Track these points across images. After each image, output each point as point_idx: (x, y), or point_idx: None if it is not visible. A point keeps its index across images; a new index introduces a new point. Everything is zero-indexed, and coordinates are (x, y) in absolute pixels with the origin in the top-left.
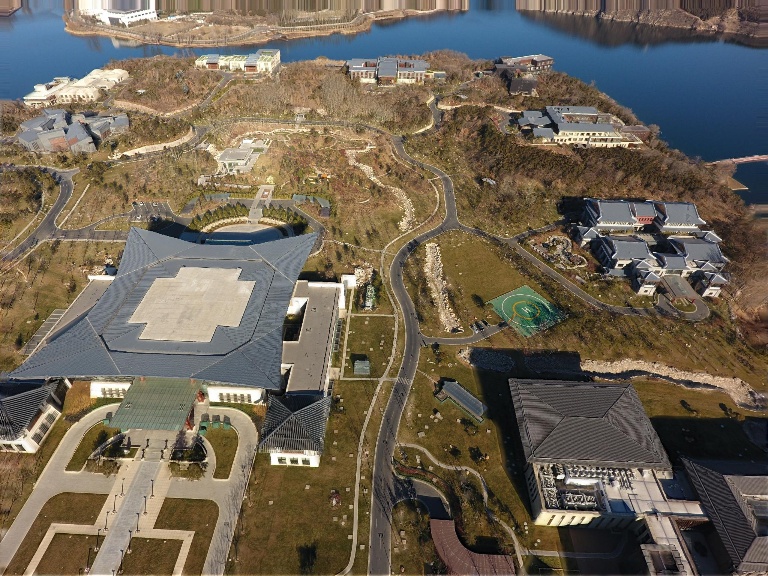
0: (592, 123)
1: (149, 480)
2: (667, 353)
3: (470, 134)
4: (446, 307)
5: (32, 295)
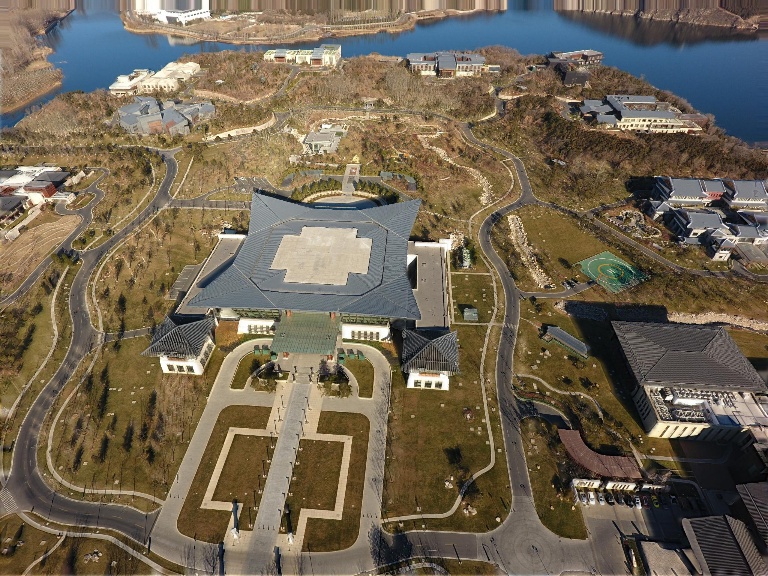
0: None
1: (304, 397)
2: (748, 307)
3: (534, 121)
4: (536, 268)
5: (165, 252)
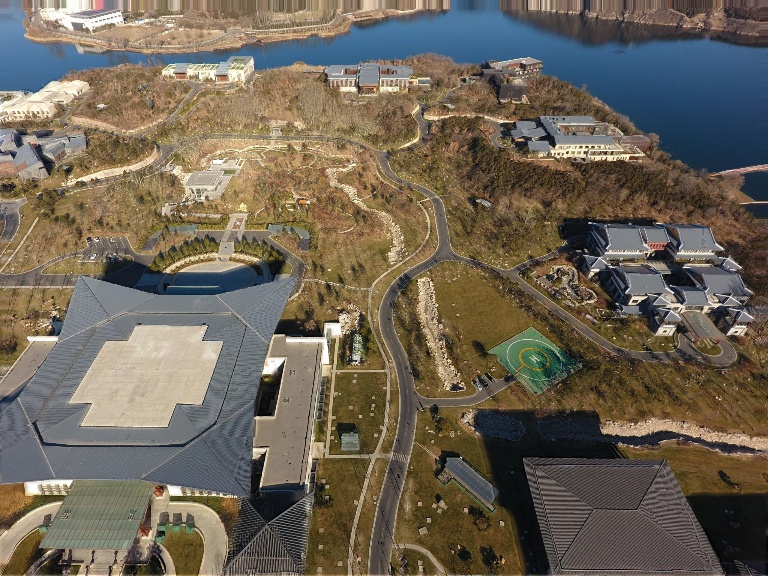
0: (589, 134)
1: None
2: (697, 411)
3: (460, 148)
4: (444, 358)
5: None
